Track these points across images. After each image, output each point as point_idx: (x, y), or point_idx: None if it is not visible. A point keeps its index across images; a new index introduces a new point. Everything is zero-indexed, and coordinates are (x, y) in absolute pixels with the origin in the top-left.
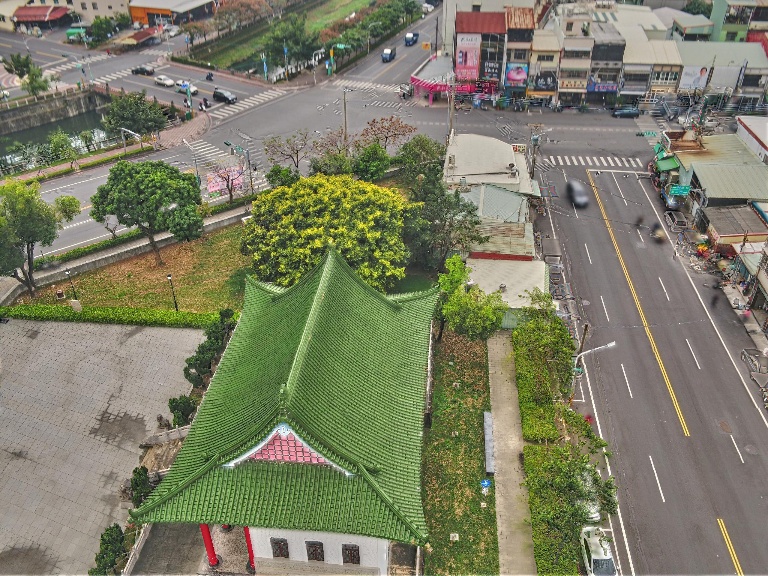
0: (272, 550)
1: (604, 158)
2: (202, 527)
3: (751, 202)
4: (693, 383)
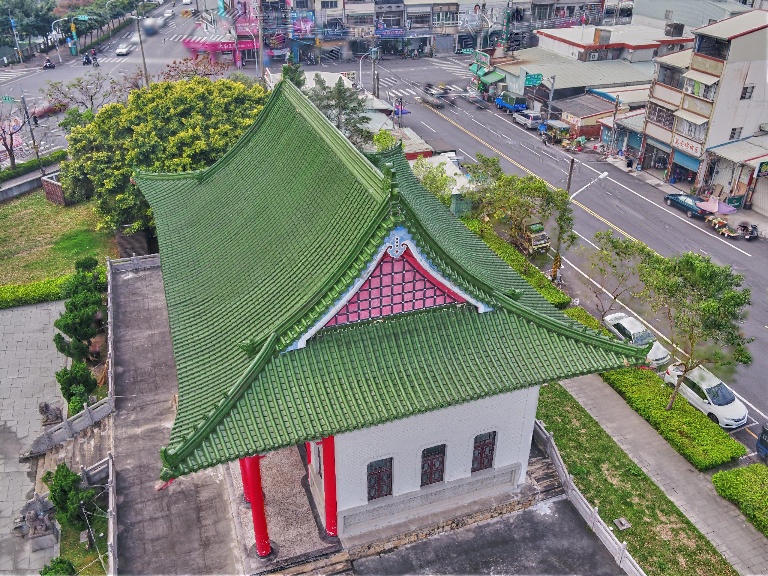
0: (367, 488)
1: None
2: (254, 482)
3: (588, 90)
4: None
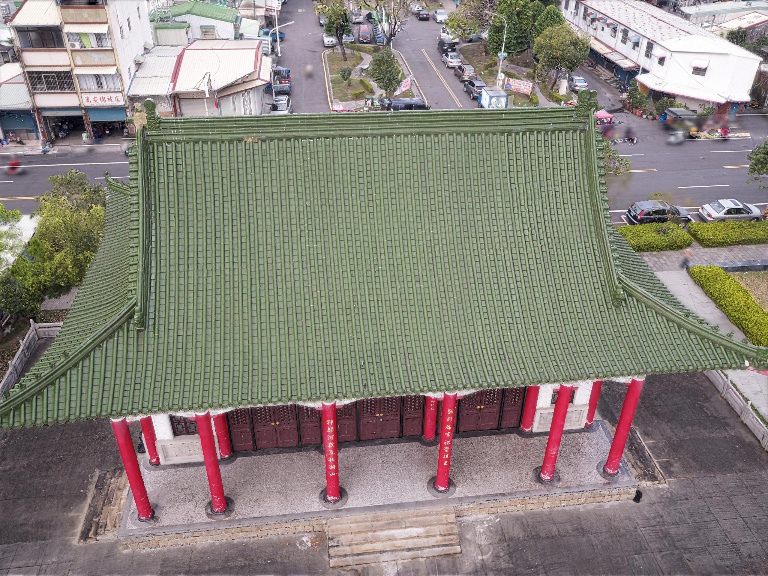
0: None
1: None
2: None
3: None
4: None
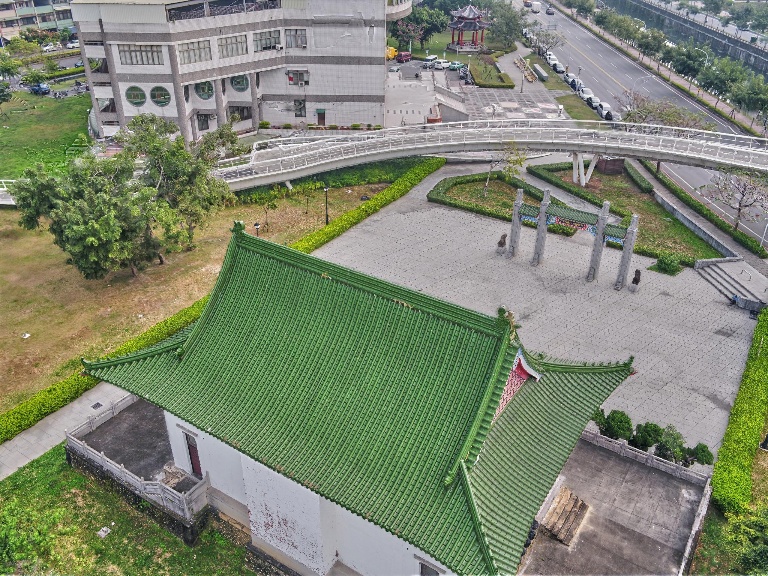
0: None
1: None
2: None
3: None
4: None
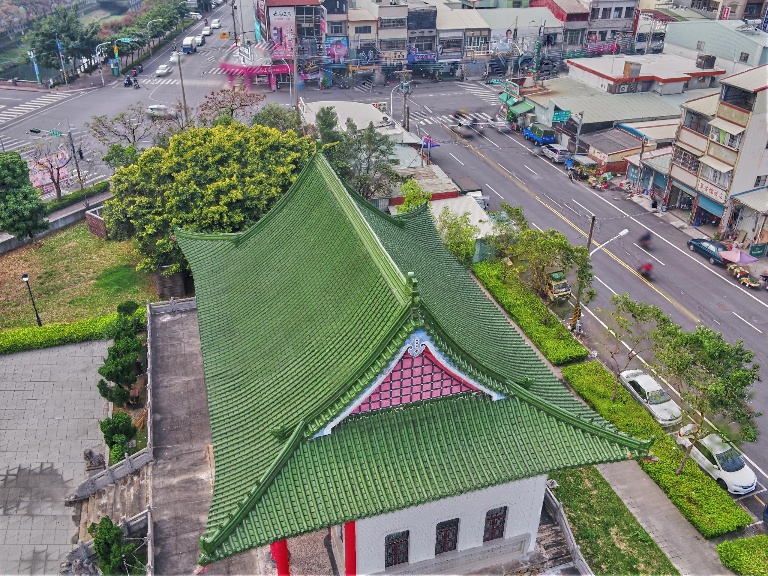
0: (384, 557)
1: (453, 115)
2: (281, 553)
3: (616, 124)
4: (668, 277)
